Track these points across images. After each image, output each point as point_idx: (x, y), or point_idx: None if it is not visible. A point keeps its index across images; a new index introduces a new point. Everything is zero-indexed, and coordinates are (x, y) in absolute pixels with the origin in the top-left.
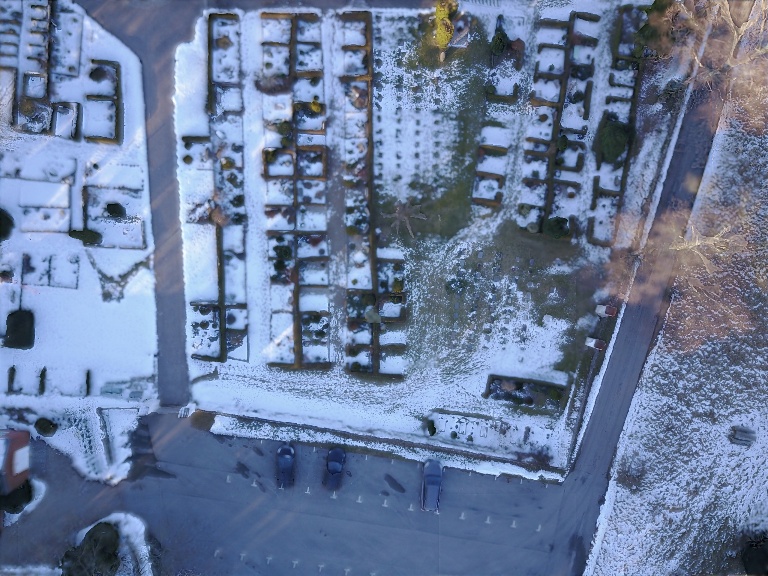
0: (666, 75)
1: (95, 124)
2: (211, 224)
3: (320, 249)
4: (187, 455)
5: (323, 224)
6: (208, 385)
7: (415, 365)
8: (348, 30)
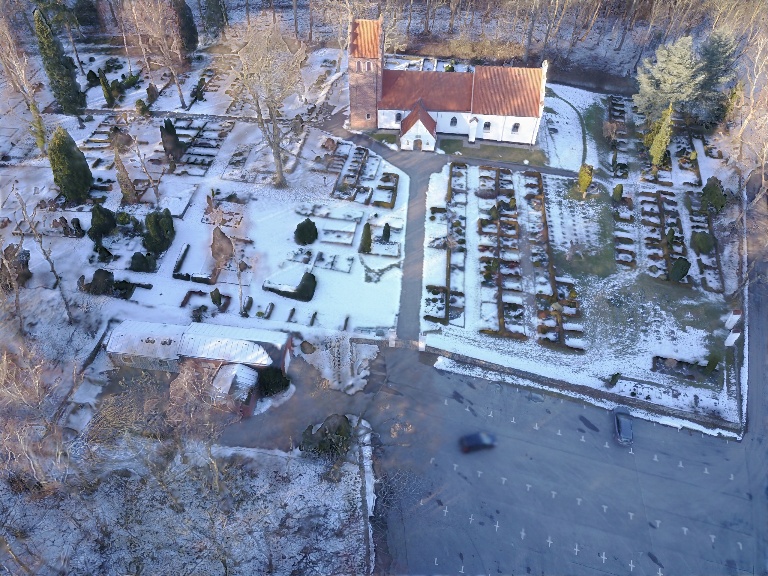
0: (726, 220)
1: (379, 198)
2: (444, 249)
3: (515, 271)
4: (413, 381)
5: (517, 259)
6: (434, 337)
7: (592, 345)
8: (528, 179)
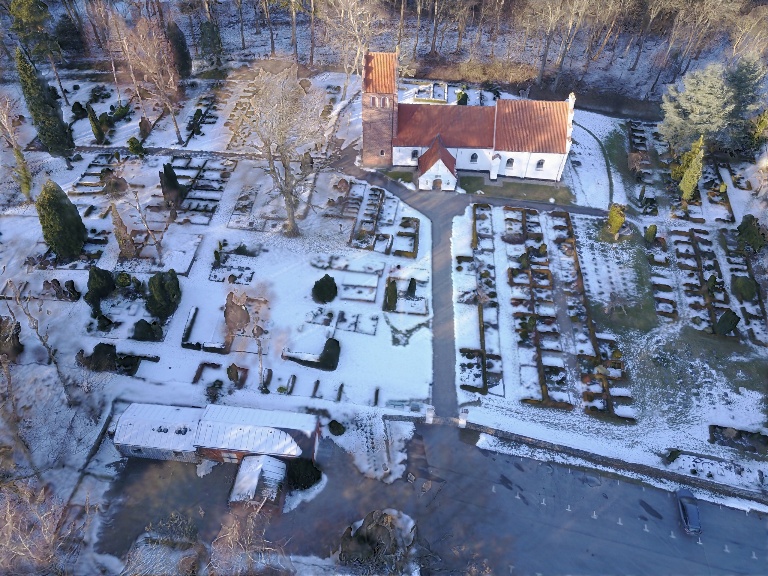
0: (765, 261)
1: (400, 247)
2: (475, 304)
3: (553, 328)
4: (456, 464)
5: (553, 314)
6: (473, 409)
7: (643, 413)
8: (555, 220)
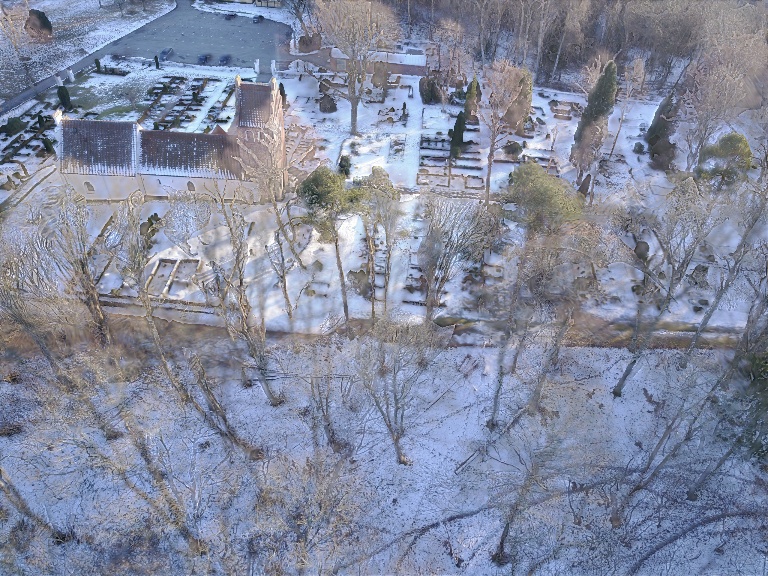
0: None
1: None
2: None
3: None
4: None
5: None
6: None
7: None
8: None
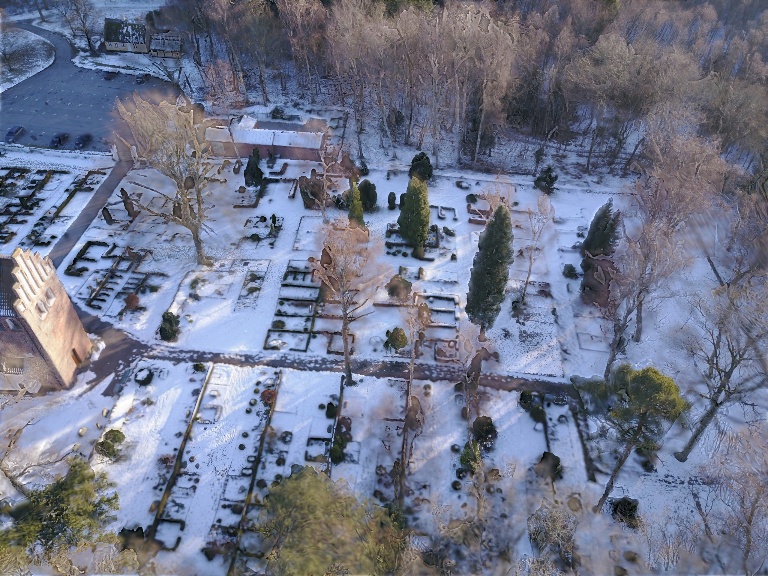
0: None
1: None
2: None
3: None
4: None
5: None
6: None
7: None
8: None
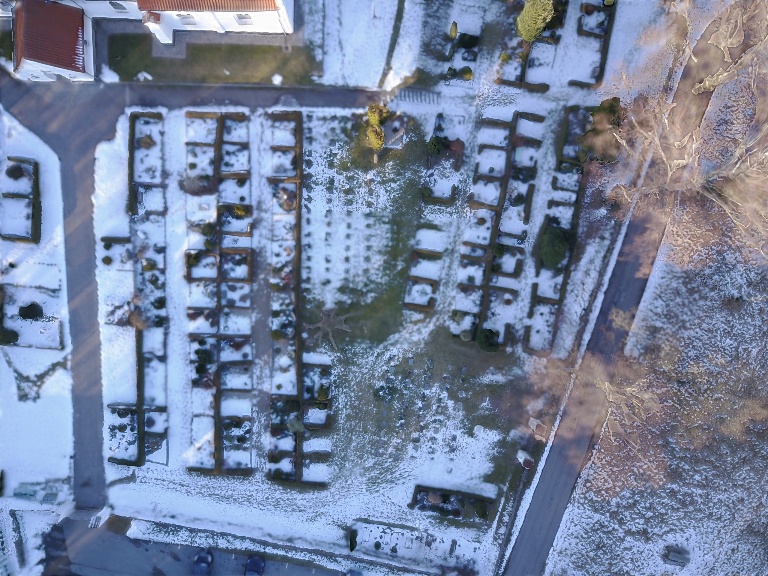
0: (612, 180)
1: (11, 222)
2: (130, 326)
3: (244, 353)
4: (102, 558)
5: (247, 327)
6: (125, 488)
7: (340, 473)
8: (277, 129)
